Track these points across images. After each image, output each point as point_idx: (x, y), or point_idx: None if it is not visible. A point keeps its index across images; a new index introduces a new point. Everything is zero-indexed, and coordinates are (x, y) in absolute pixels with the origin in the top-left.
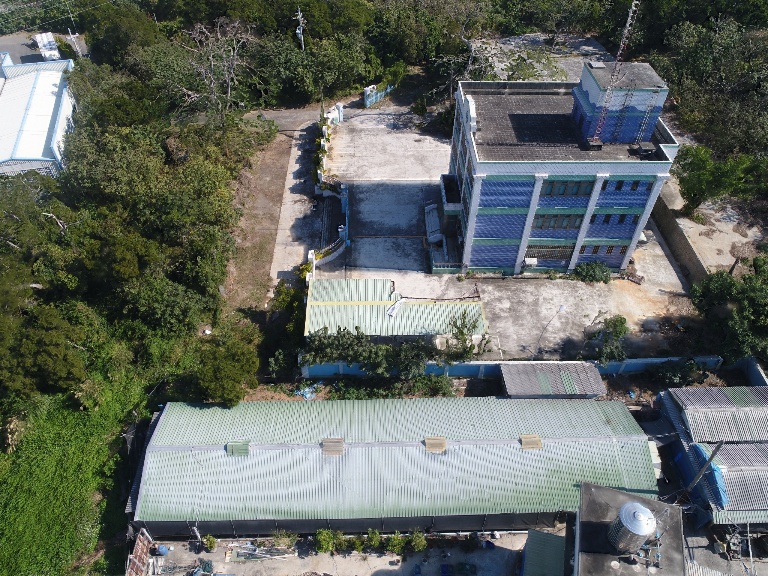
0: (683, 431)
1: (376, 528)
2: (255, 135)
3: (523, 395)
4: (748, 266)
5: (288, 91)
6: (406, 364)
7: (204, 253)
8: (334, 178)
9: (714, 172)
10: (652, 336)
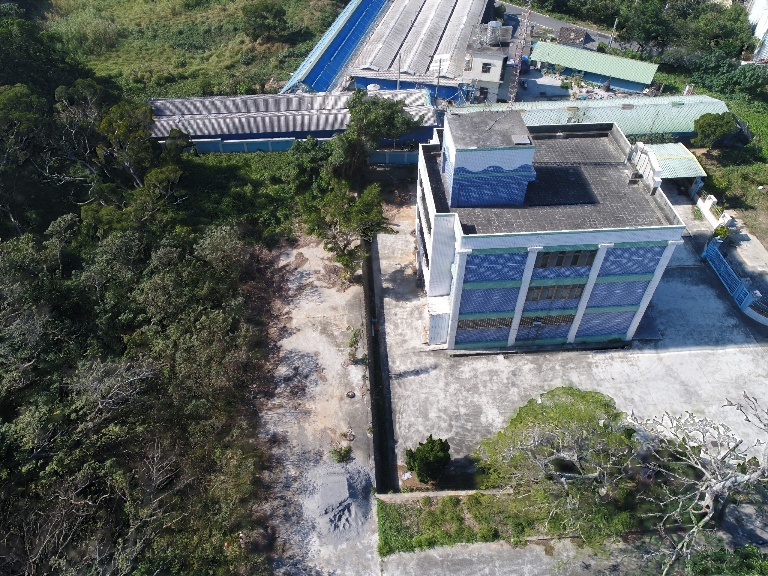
0: None
1: None
2: None
3: None
4: None
5: None
6: None
7: None
8: None
9: None
10: None
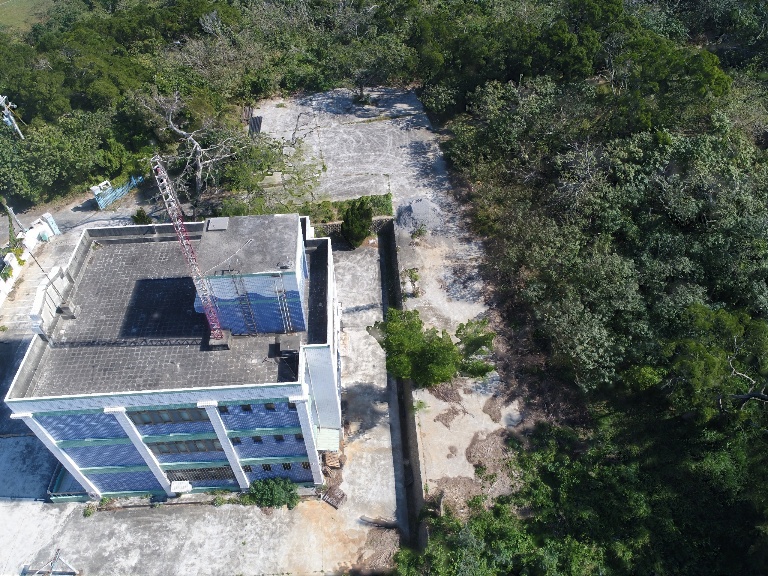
0: None
1: None
2: None
3: None
4: (483, 478)
5: None
6: None
7: None
8: None
9: (424, 352)
10: None
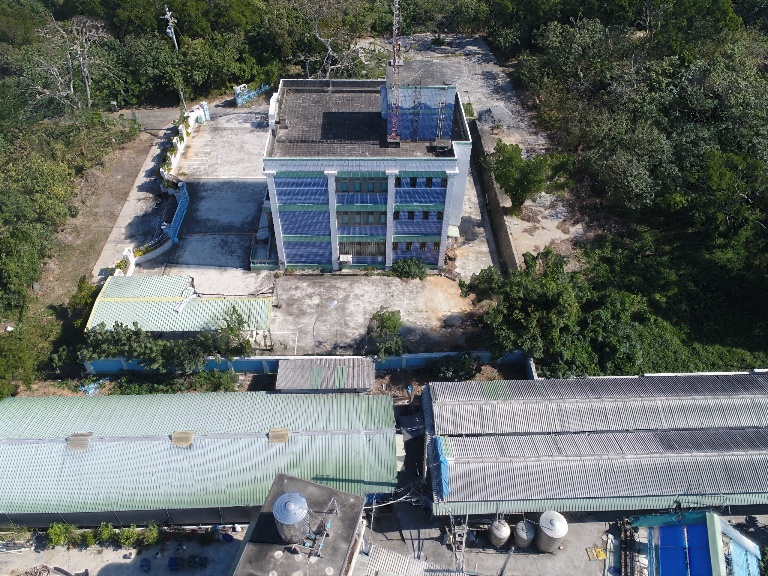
0: (430, 424)
1: (111, 522)
2: (119, 134)
3: (291, 390)
4: None
5: (164, 90)
6: (182, 359)
7: (11, 250)
8: (175, 176)
9: (524, 169)
10: (451, 331)
